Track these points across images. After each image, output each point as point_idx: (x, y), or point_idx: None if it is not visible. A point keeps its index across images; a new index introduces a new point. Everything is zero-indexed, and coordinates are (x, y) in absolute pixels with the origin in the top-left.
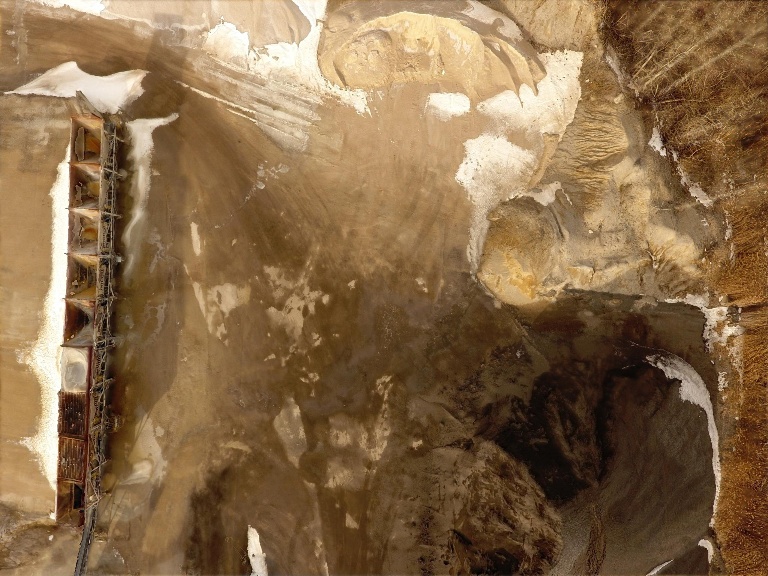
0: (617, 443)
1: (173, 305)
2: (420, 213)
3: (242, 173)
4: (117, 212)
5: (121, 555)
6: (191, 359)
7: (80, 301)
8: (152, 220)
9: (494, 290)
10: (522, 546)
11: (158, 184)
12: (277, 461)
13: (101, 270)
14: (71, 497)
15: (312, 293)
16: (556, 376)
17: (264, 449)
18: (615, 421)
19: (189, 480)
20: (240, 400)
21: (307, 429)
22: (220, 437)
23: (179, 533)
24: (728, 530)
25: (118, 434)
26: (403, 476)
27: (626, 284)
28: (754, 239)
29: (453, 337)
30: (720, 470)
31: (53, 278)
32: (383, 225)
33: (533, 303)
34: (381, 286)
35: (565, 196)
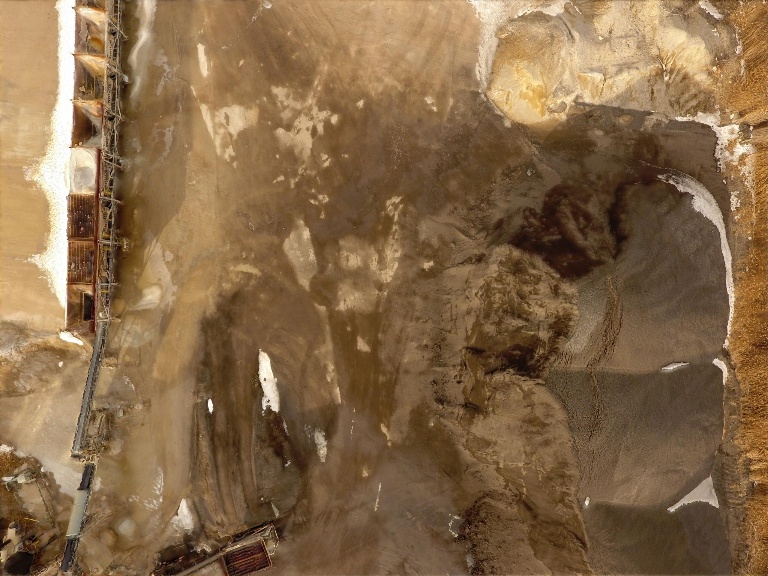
0: (631, 229)
1: (181, 128)
2: (428, 31)
3: None
4: (123, 31)
5: (131, 382)
6: (199, 182)
7: (88, 106)
8: (158, 42)
9: (504, 108)
10: (537, 334)
11: (164, 5)
12: (287, 284)
13: (108, 84)
14: (81, 308)
15: (320, 113)
16: (568, 186)
17: (274, 272)
18: (629, 213)
19: (199, 304)
20: (249, 223)
21: (317, 251)
22: (230, 260)
23: (190, 358)
24: (743, 349)
25: (127, 259)
26: (414, 298)
27: (637, 97)
28: (765, 51)
29: (463, 157)
30: (734, 291)
31: (60, 92)
32: (391, 43)
33: (543, 121)
34: (390, 105)
35: (574, 8)
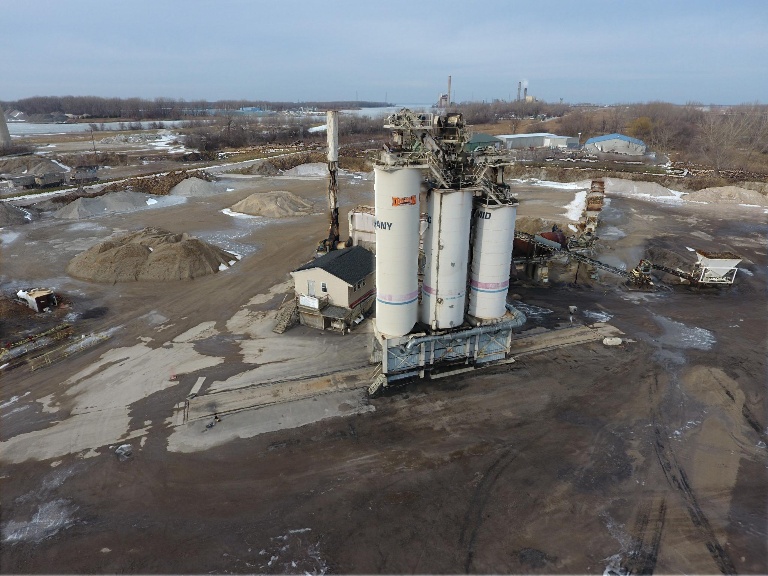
0: None
1: None
2: None
3: (653, 205)
4: None
5: None
6: None
7: None
8: None
9: None
10: None
11: None
12: None
13: None
14: None
15: None
16: None
17: None
18: None
19: None
20: None
21: None
22: None
23: None
24: None
25: None
26: None
27: None
28: None
29: None
30: None
31: None
32: None
33: None
34: None
35: None
